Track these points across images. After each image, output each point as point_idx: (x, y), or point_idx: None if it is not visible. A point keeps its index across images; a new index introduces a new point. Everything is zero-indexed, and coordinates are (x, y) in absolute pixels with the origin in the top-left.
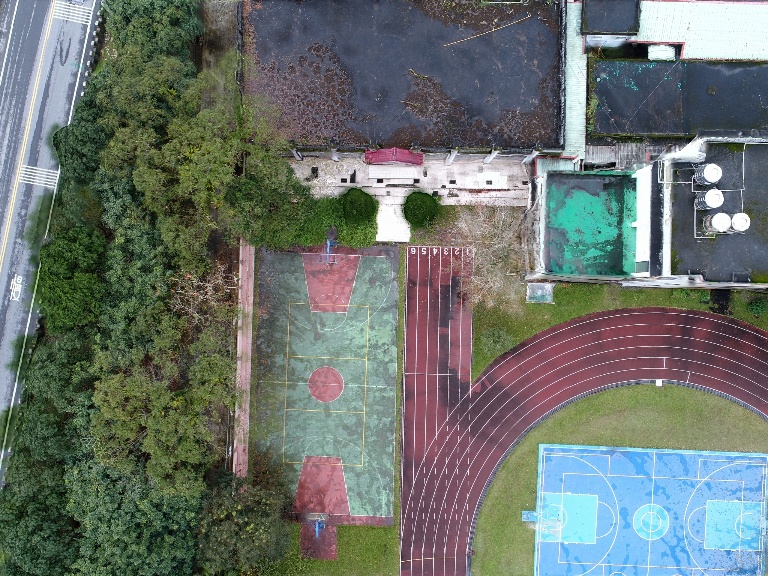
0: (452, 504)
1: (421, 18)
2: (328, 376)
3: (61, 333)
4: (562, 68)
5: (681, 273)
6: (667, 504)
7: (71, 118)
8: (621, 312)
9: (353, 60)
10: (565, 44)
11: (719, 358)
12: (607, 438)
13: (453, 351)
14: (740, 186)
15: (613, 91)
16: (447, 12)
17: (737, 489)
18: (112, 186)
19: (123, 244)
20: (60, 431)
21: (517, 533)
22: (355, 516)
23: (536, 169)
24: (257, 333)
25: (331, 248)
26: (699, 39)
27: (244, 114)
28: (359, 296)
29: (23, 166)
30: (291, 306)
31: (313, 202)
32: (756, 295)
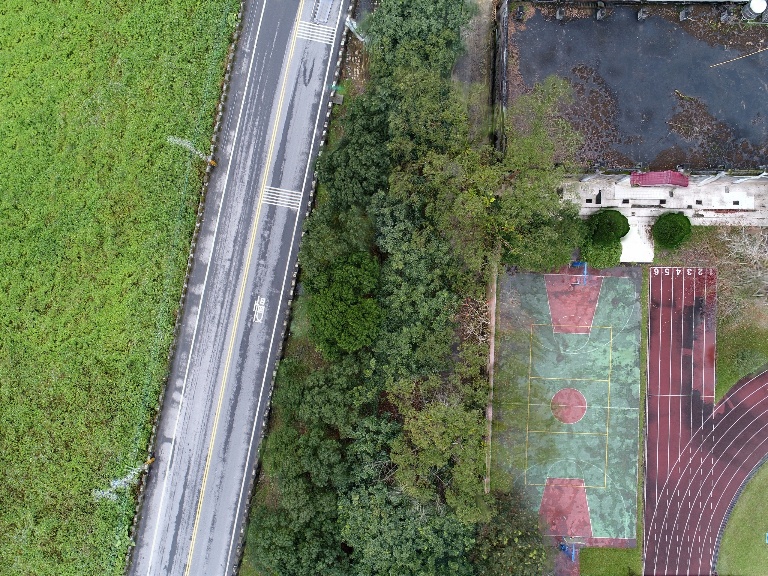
0: (695, 526)
1: (686, 39)
2: (571, 398)
3: (337, 358)
4: None
5: None
6: None
7: (314, 139)
8: None
9: (618, 81)
10: None
11: None
12: None
13: (696, 372)
14: None
15: None
16: (713, 33)
17: None
18: (392, 210)
19: (403, 269)
20: (343, 457)
21: (761, 555)
22: (598, 538)
23: None
24: (499, 354)
25: (574, 269)
26: None
27: (505, 136)
28: (602, 317)
29: (266, 187)
30: (533, 327)
31: (557, 223)
32: None
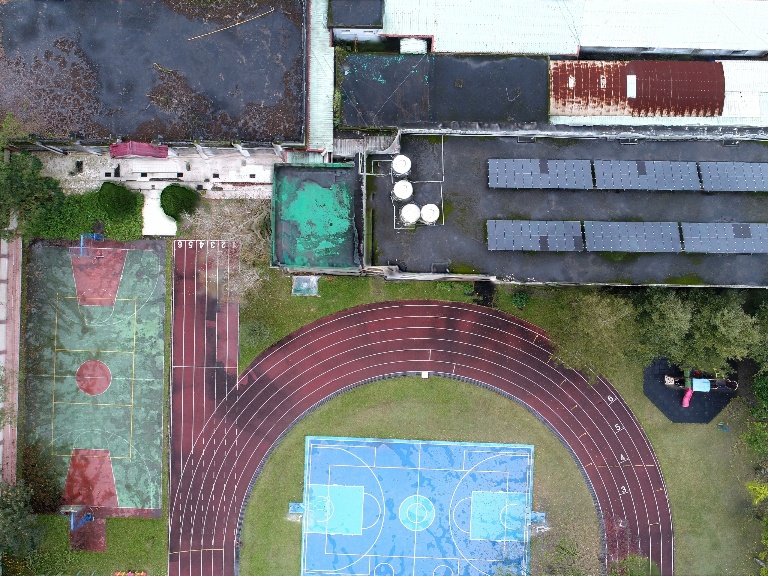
0: (220, 496)
1: (166, 12)
2: (96, 369)
3: None
4: (303, 61)
5: (382, 264)
6: (432, 495)
7: None
8: (386, 305)
9: (98, 54)
10: (303, 37)
11: (484, 350)
12: (373, 430)
13: (220, 344)
14: (440, 177)
15: (361, 84)
16: (191, 6)
17: (502, 480)
18: None
19: None
20: None
21: (284, 525)
22: (123, 508)
23: None
24: (25, 327)
25: (98, 242)
26: (447, 32)
27: None
28: (126, 290)
29: None
30: (59, 300)
31: (78, 196)
32: (520, 287)
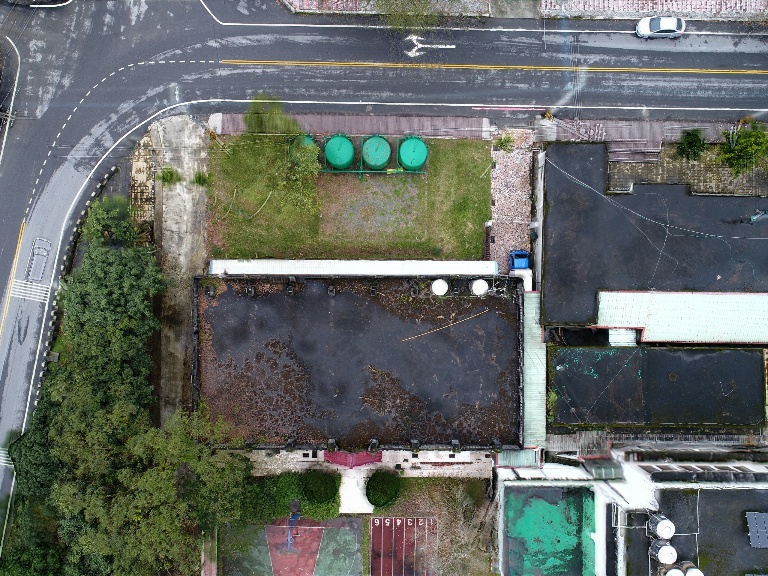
0: None
1: (378, 313)
2: None
3: None
4: (520, 365)
5: None
6: None
7: (30, 396)
8: None
9: (310, 356)
10: None
11: None
12: None
13: None
14: (695, 529)
15: (573, 379)
16: (404, 307)
17: None
18: (67, 505)
19: (79, 563)
20: None
21: None
22: None
23: (497, 458)
24: None
25: (294, 520)
26: (659, 324)
27: None
28: (323, 568)
29: None
30: None
31: (275, 476)
32: None
